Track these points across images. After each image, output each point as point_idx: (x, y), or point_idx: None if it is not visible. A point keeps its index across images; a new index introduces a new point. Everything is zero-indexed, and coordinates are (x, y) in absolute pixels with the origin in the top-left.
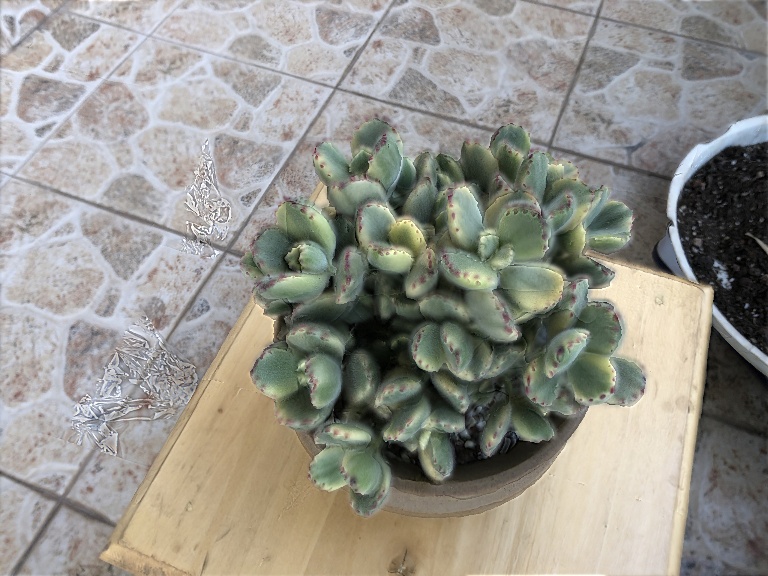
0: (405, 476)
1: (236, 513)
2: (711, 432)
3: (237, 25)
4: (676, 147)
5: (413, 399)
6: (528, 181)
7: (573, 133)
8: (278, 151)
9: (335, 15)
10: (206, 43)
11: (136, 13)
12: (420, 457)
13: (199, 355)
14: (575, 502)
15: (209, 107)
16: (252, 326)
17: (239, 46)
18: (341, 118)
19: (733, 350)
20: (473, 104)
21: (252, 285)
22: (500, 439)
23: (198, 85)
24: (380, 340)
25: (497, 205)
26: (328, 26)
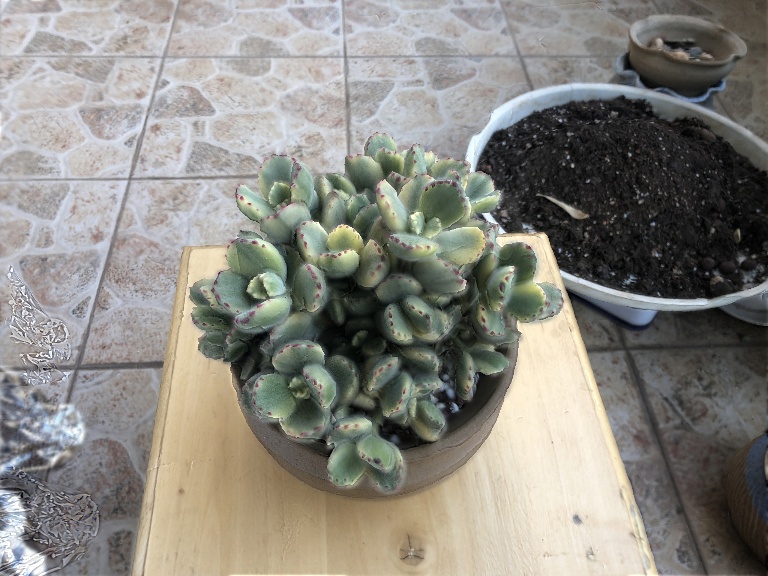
0: (406, 446)
1: (240, 575)
2: None
3: None
4: (452, 146)
5: (397, 372)
6: (417, 168)
7: None
8: (94, 255)
9: (101, 112)
10: None
11: None
12: (412, 425)
13: (88, 481)
14: (522, 434)
15: None
16: (177, 402)
17: (9, 166)
18: (147, 205)
19: None
20: None
21: (119, 391)
22: (473, 380)
23: None
24: (340, 342)
25: (404, 192)
26: (98, 124)
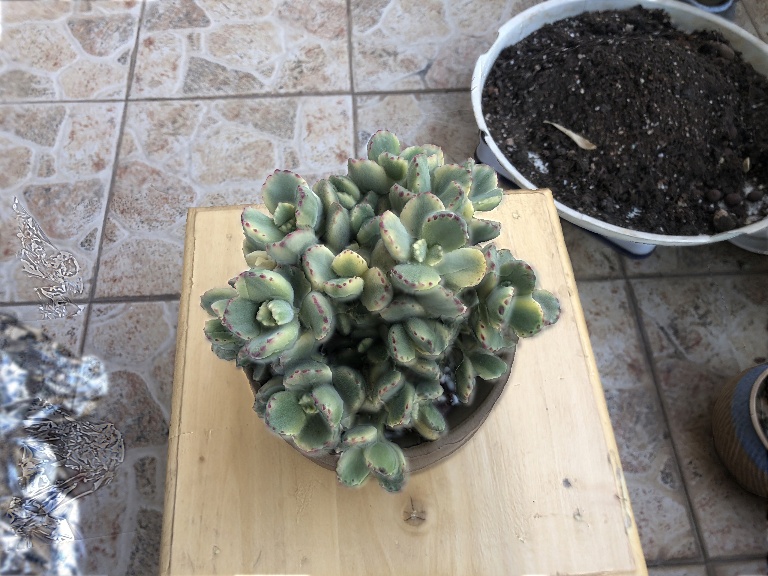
0: (409, 445)
1: (259, 535)
2: None
3: None
4: (458, 59)
5: (400, 386)
6: (420, 180)
7: (368, 74)
8: (96, 184)
9: (91, 24)
10: None
11: None
12: (415, 425)
13: (111, 412)
14: (518, 401)
15: (0, 163)
16: (193, 372)
17: (2, 87)
18: (146, 129)
19: (565, 220)
20: (267, 75)
21: (133, 325)
22: (472, 386)
23: None
24: (346, 348)
25: (407, 210)
26: (89, 37)
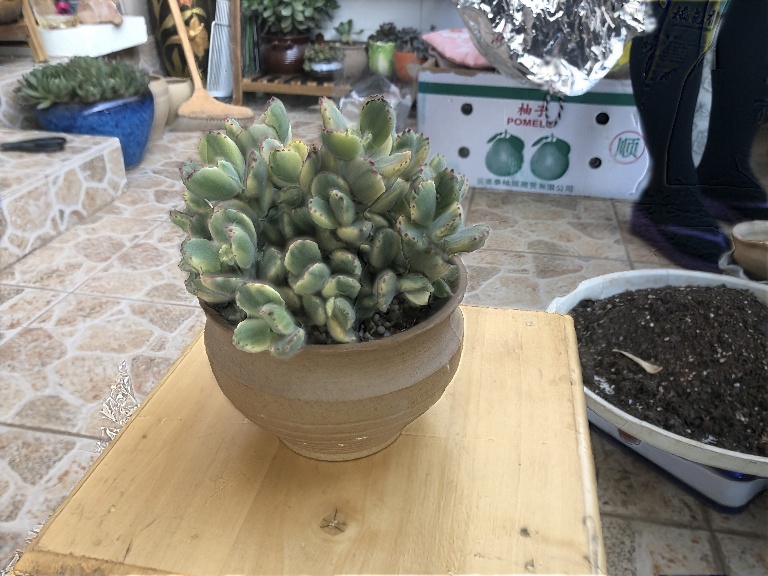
0: (318, 343)
1: (162, 506)
2: (641, 533)
3: (154, 278)
4: None
5: (315, 259)
6: None
7: None
8: None
9: None
10: (125, 293)
11: (60, 278)
12: (329, 327)
13: None
14: (489, 452)
15: (127, 337)
16: (175, 379)
17: (156, 292)
18: None
19: (638, 460)
20: None
21: None
22: (390, 287)
23: (116, 322)
24: None
25: None
26: None
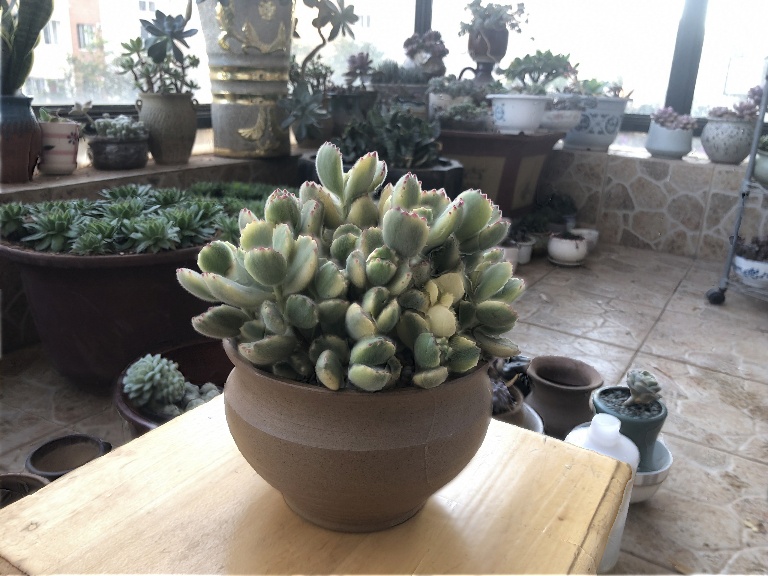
0: None
1: None
2: None
3: None
4: None
5: None
6: None
7: None
8: None
9: None
10: None
11: None
12: None
13: None
14: None
15: None
16: None
17: None
18: None
19: None
20: None
21: None
22: None
23: None
24: None
25: None
26: None
